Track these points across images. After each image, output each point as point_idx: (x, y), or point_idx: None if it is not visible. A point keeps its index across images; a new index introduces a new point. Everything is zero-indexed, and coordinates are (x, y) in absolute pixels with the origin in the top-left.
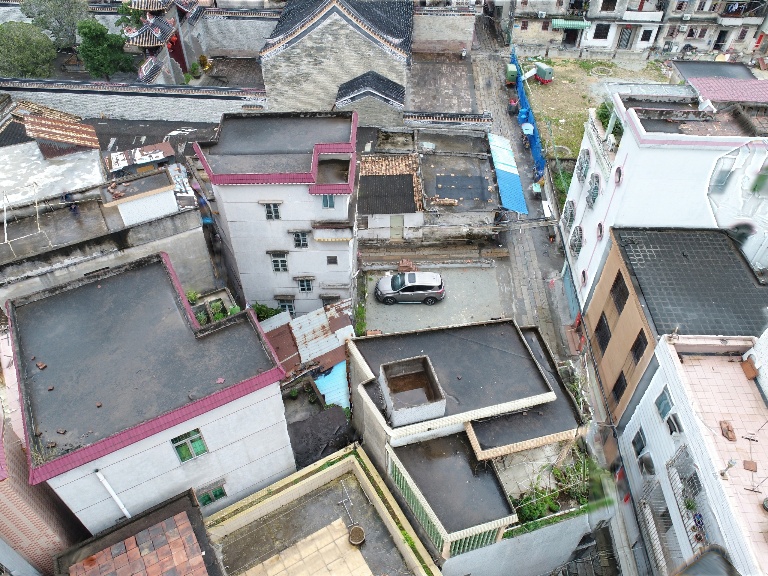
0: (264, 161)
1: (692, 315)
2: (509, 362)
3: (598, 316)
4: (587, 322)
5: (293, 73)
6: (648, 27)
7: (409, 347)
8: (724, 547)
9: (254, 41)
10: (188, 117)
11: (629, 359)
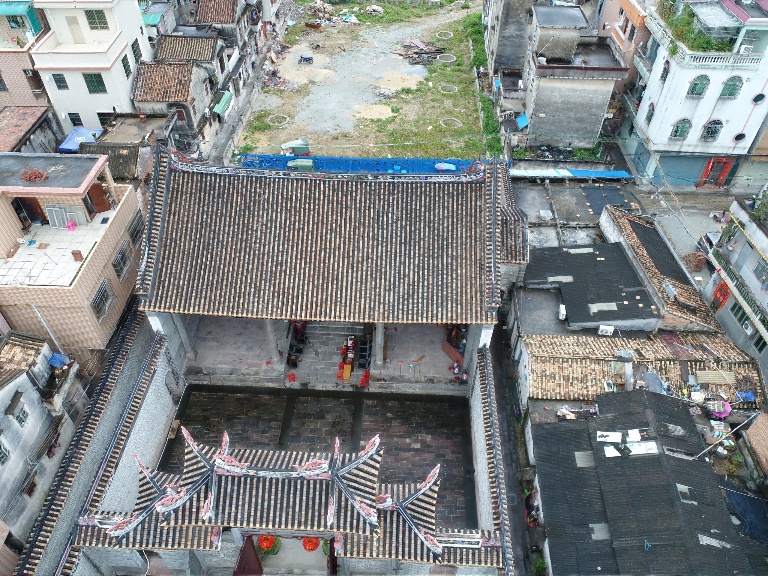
0: None
1: None
2: None
3: None
4: (762, 151)
5: None
6: None
7: None
8: None
9: (146, 447)
10: None
11: None
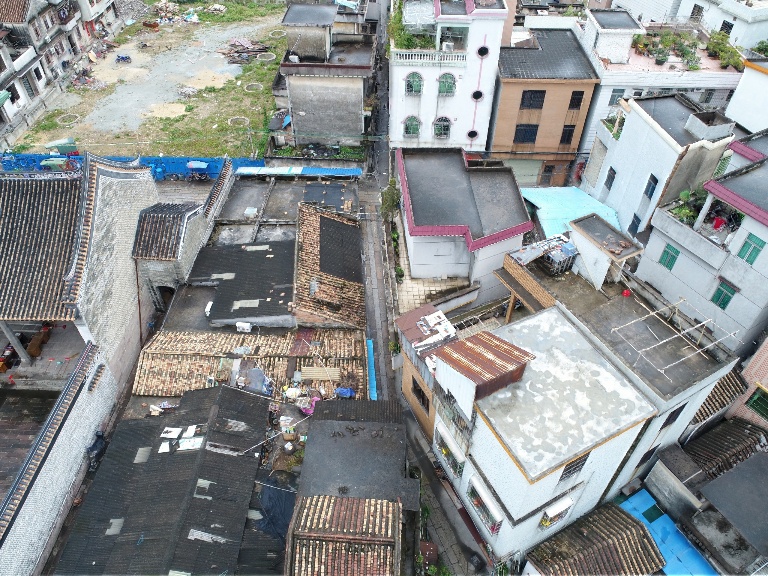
0: (488, 201)
1: (572, 69)
2: (661, 105)
3: (512, 133)
4: (499, 148)
5: (102, 288)
6: (35, 66)
7: (671, 132)
8: (688, 97)
9: None
10: (53, 492)
11: (570, 114)
